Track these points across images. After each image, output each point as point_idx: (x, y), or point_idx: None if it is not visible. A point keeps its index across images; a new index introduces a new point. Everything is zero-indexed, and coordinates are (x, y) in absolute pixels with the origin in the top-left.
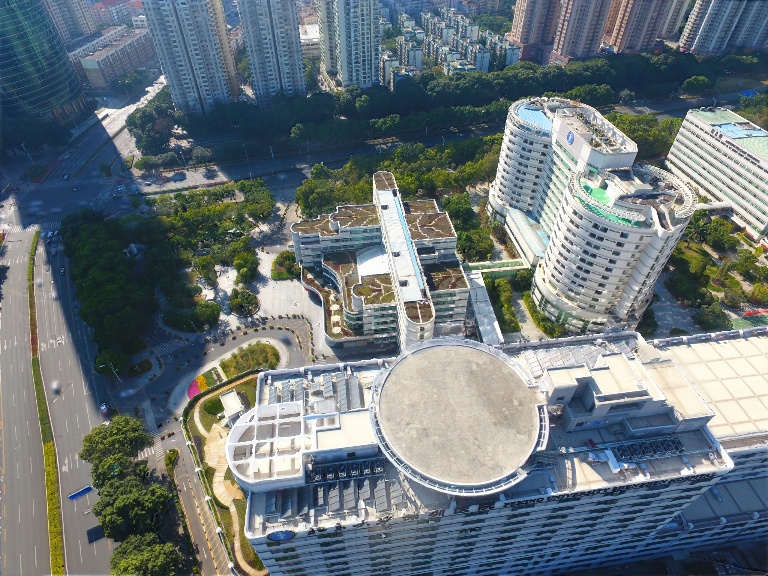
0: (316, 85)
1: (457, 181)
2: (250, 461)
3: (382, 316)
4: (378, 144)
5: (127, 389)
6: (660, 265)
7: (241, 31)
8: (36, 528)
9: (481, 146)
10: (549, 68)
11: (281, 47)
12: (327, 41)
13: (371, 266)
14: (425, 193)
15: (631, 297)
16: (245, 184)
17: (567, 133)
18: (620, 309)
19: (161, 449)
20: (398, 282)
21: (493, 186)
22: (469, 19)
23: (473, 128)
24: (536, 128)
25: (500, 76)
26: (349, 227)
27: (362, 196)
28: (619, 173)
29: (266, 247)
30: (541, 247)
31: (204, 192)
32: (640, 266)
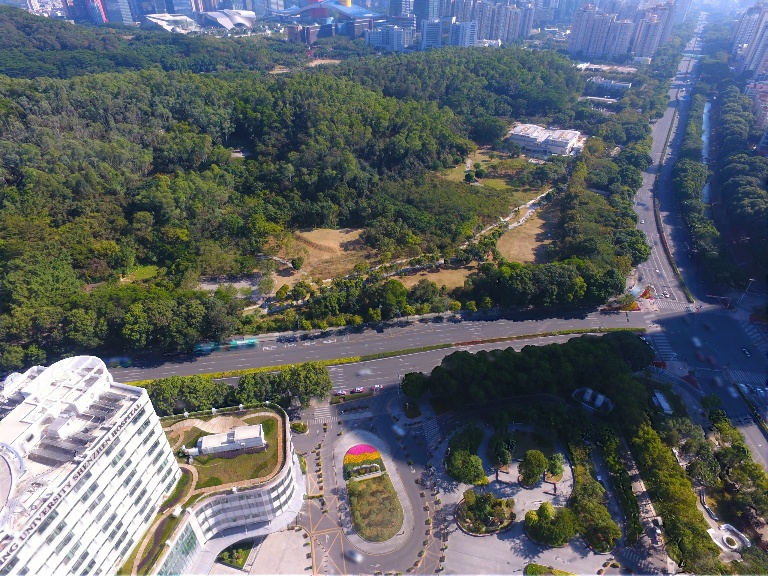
0: None
1: None
2: (66, 366)
3: None
4: None
5: (392, 401)
6: None
7: None
8: (297, 359)
9: None
10: None
11: None
12: None
13: None
14: None
15: None
16: None
17: None
18: None
19: (315, 423)
20: None
21: None
22: None
23: None
24: None
25: None
26: None
27: None
28: None
29: (618, 572)
30: None
31: (762, 486)
32: None
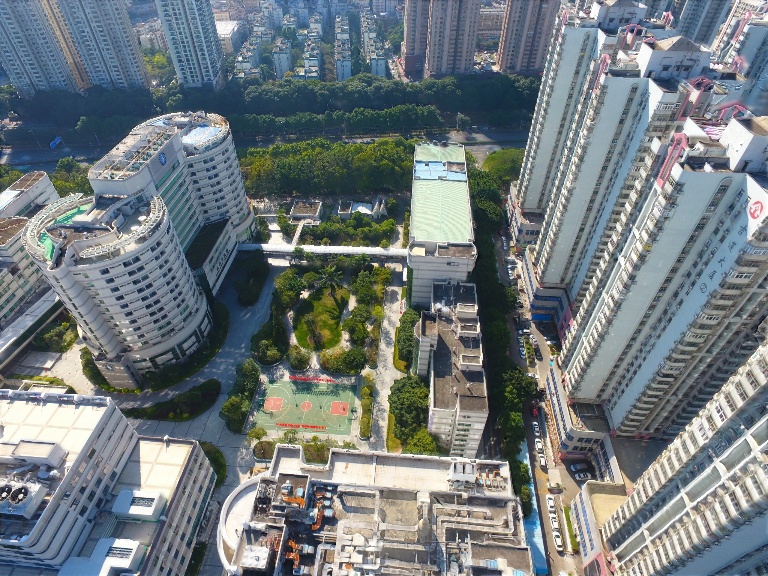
0: None
1: None
2: None
3: None
4: None
5: None
6: (116, 306)
7: (150, 23)
8: None
9: None
10: (388, 83)
11: (101, 41)
12: None
13: None
14: None
15: None
16: None
17: None
18: None
19: None
20: None
21: None
22: (374, 25)
23: (279, 138)
24: None
25: (326, 87)
26: None
27: None
28: (109, 201)
29: None
30: None
31: None
32: None
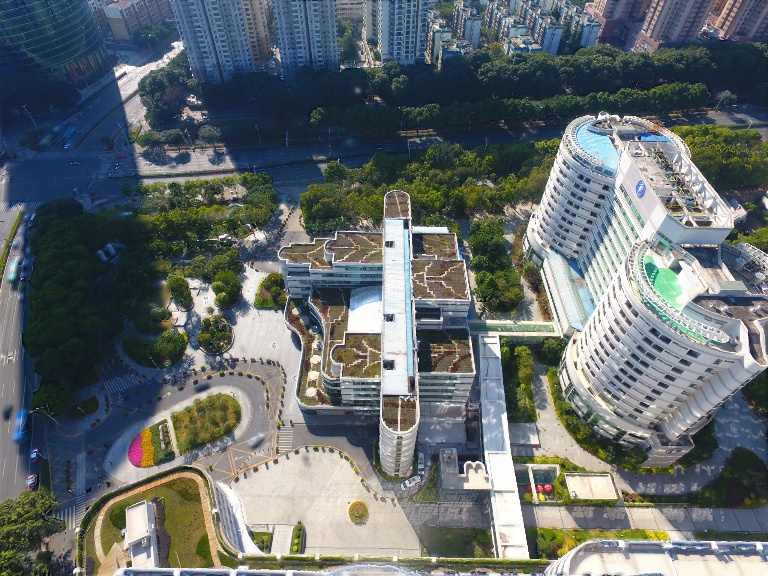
0: (354, 54)
1: (493, 200)
2: None
3: (364, 389)
4: (411, 137)
5: (65, 433)
6: None
7: None
8: None
9: (530, 155)
10: (632, 56)
11: (312, 11)
12: (370, 4)
13: (364, 315)
14: (453, 209)
15: (688, 421)
16: (248, 178)
17: (637, 181)
18: (670, 428)
19: None
20: (382, 362)
21: (534, 216)
22: None
23: (527, 125)
24: (597, 163)
25: (569, 62)
26: (344, 263)
27: (374, 212)
28: (701, 253)
29: (257, 262)
30: (580, 315)
31: (201, 184)
32: (708, 391)
